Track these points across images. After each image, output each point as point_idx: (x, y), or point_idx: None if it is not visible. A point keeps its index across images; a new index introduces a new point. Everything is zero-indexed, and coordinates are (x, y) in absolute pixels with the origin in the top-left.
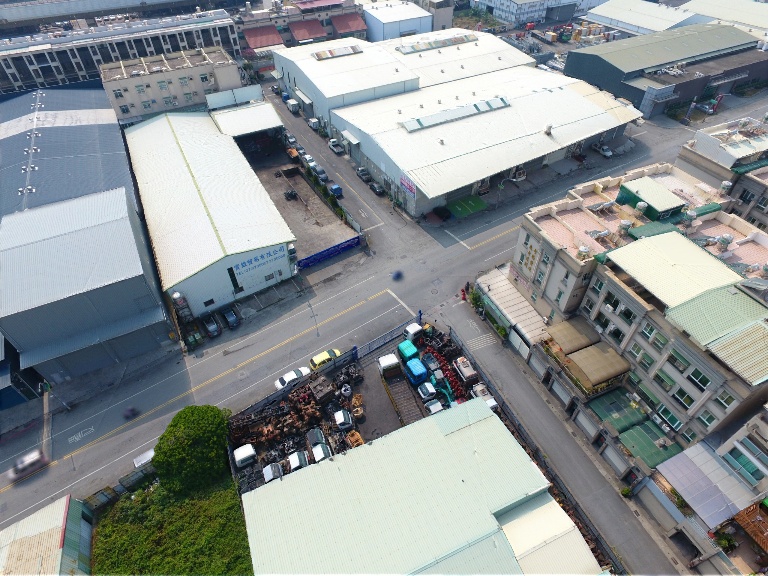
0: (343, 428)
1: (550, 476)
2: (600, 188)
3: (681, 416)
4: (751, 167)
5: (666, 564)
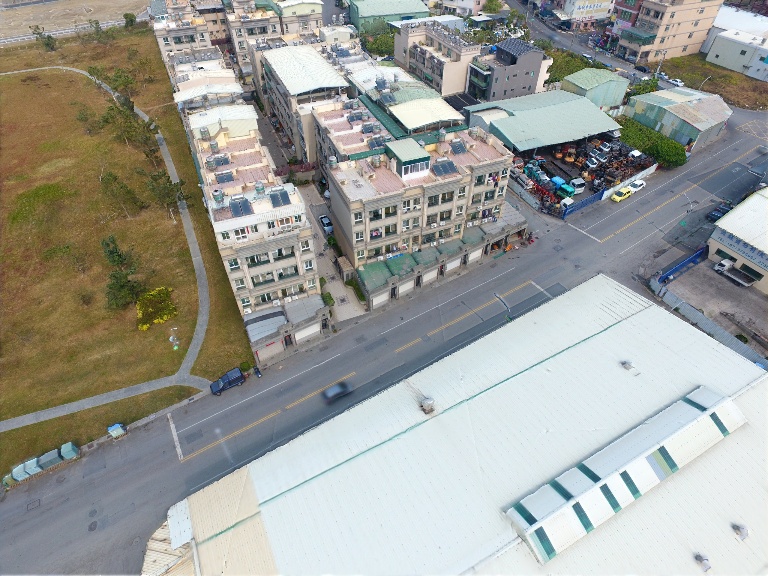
0: None
1: None
2: None
3: None
4: None
5: None
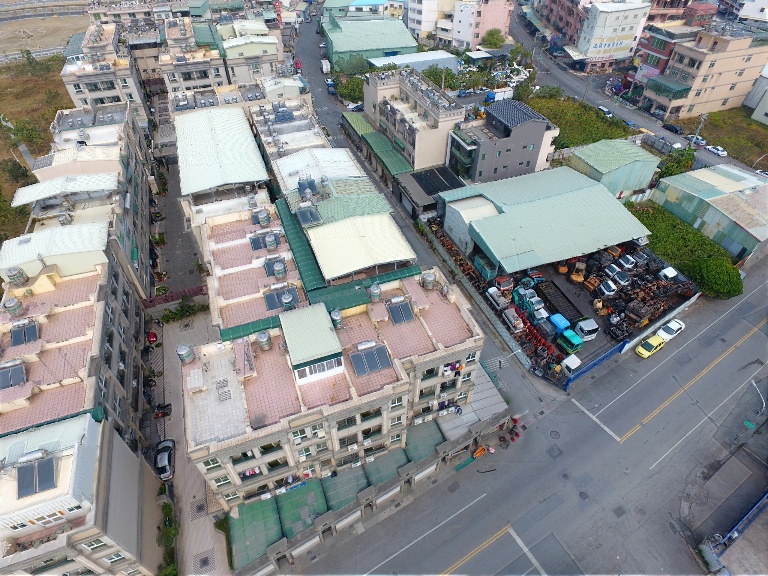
0: None
1: (450, 269)
2: (354, 389)
3: None
4: (69, 416)
5: None
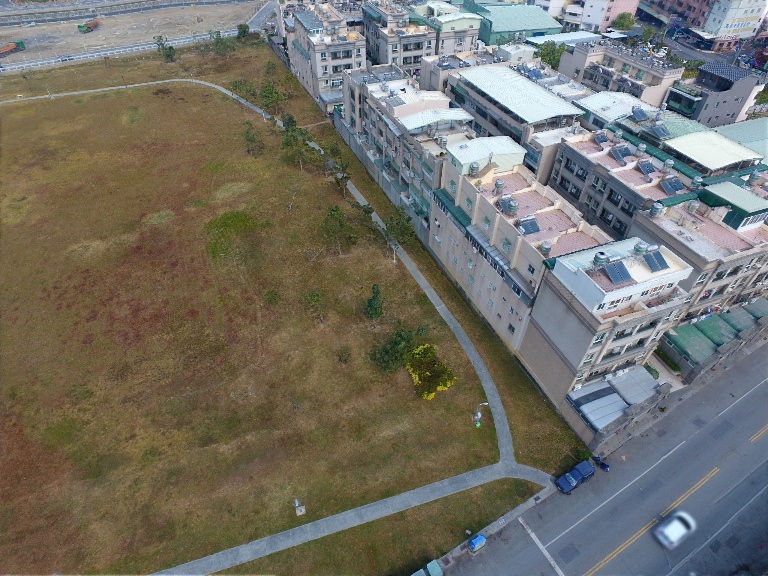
0: None
1: None
2: None
3: None
4: None
5: None
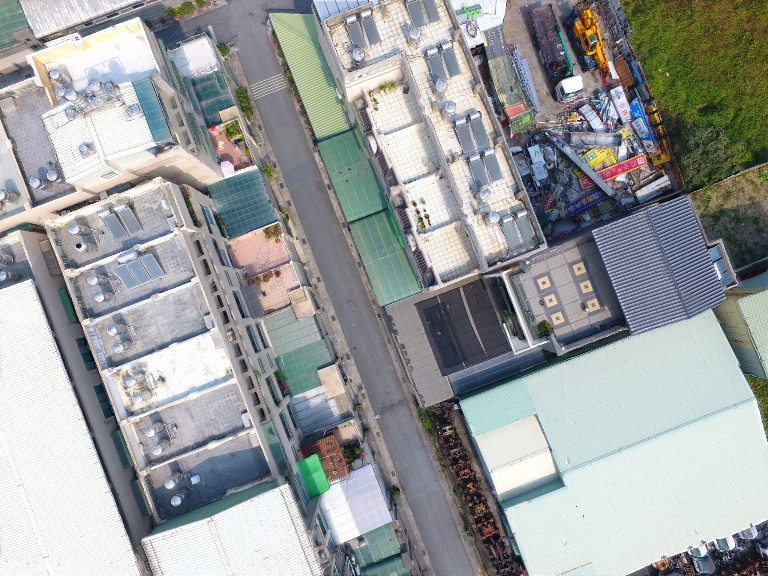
0: (674, 573)
1: (463, 511)
2: None
3: (348, 575)
4: None
5: (387, 433)
